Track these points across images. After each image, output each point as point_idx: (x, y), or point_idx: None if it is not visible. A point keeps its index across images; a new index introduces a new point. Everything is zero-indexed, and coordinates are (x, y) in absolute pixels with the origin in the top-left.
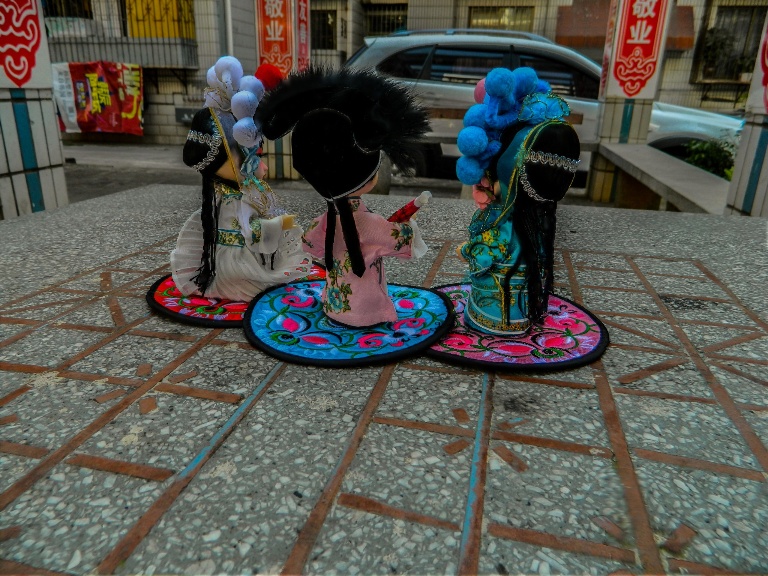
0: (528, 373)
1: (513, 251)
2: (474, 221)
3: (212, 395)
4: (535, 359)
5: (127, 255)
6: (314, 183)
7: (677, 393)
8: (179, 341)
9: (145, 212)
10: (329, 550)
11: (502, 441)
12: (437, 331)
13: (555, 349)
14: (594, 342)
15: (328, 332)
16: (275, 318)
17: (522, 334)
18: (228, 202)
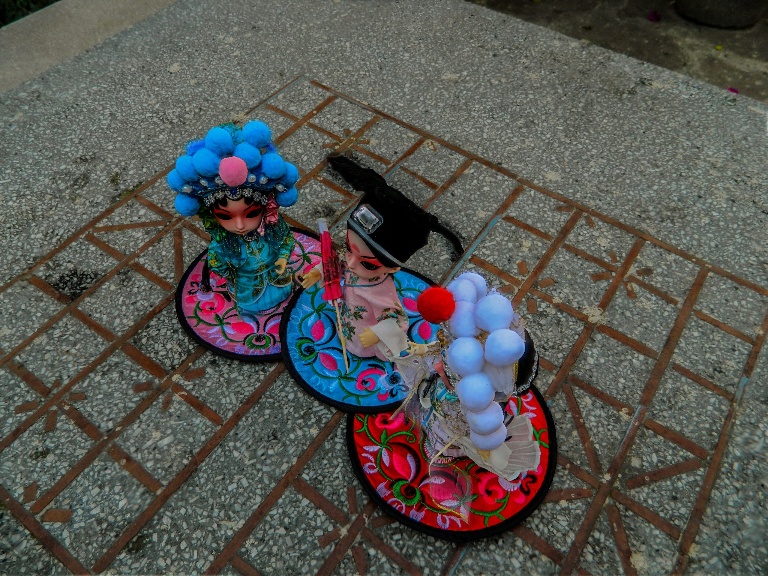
0: None
1: None
2: None
3: (487, 266)
4: None
5: None
6: None
7: None
8: None
9: None
10: (447, 173)
11: (355, 194)
12: None
13: None
14: None
15: None
16: None
17: None
18: None
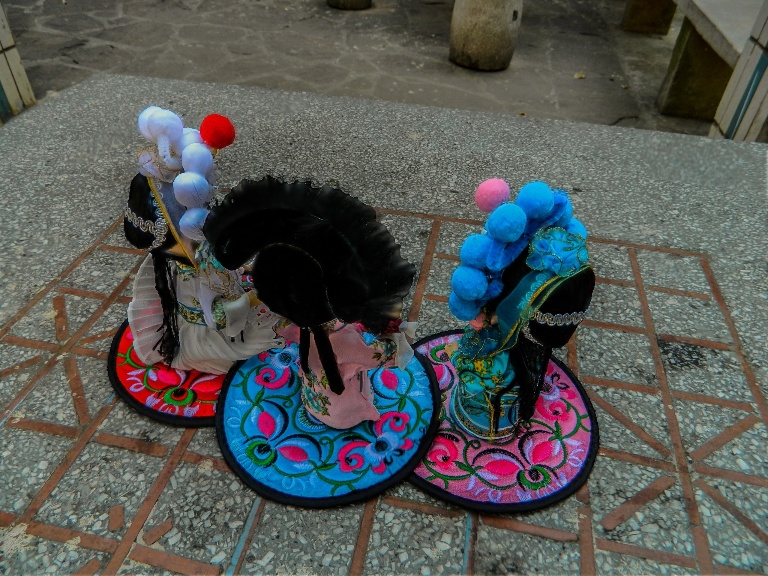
0: (512, 514)
1: (507, 376)
2: (466, 346)
3: (190, 568)
4: (521, 495)
5: (80, 255)
6: (282, 316)
7: (659, 548)
8: (149, 457)
9: (93, 149)
10: None
11: None
12: (421, 446)
13: (542, 469)
14: (583, 454)
15: (307, 437)
16: (250, 413)
17: (510, 436)
18: (185, 279)
